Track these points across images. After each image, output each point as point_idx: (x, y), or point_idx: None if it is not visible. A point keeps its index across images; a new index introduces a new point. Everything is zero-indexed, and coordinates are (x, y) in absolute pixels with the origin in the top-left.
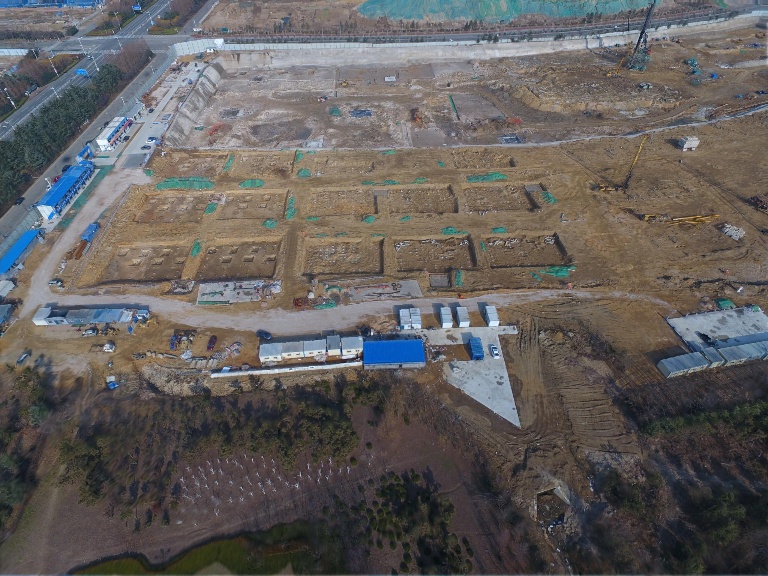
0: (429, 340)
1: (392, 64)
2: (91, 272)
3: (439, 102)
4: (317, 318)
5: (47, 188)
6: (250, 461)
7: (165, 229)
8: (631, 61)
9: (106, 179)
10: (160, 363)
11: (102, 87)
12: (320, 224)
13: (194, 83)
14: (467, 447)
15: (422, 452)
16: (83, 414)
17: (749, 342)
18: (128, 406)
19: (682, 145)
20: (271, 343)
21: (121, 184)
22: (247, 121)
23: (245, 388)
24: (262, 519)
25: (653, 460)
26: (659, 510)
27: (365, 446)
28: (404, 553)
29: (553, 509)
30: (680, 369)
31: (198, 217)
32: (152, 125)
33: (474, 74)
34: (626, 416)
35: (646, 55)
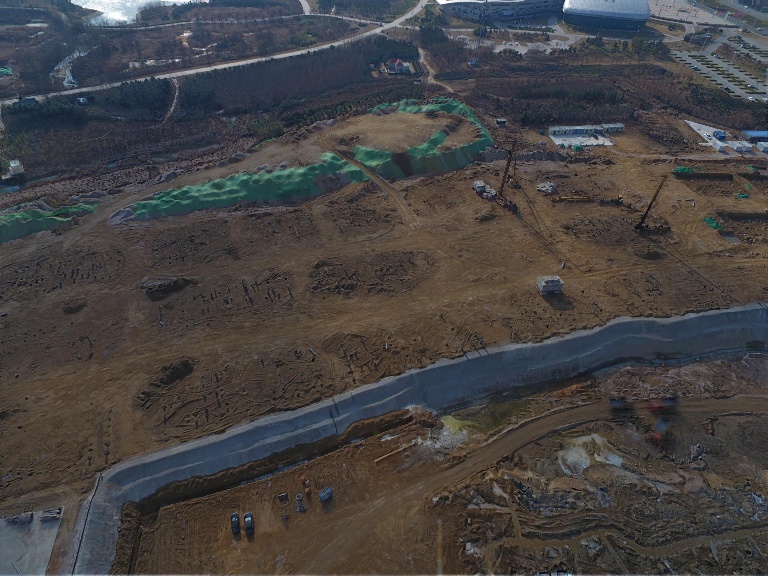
0: None
1: None
2: None
3: None
4: None
5: None
6: None
7: None
8: None
9: None
10: None
11: None
12: None
13: None
14: None
15: None
16: None
17: (572, 135)
18: None
19: None
20: None
21: None
22: None
23: None
24: (766, 110)
25: None
26: None
27: None
28: None
29: None
30: None
31: None
32: None
33: None
34: None
35: None
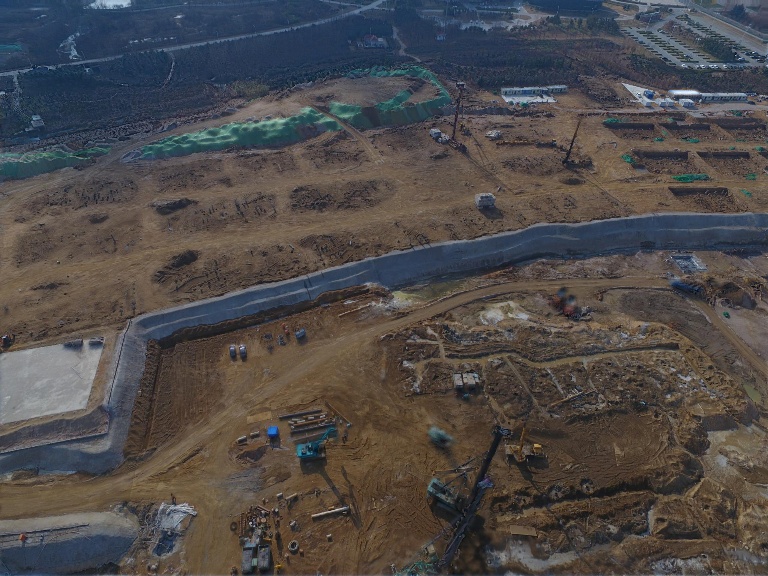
0: (671, 99)
1: None
2: None
3: None
4: (733, 107)
5: None
6: None
7: None
8: None
9: None
10: None
11: None
12: None
13: None
14: None
15: None
16: None
17: (521, 95)
18: None
19: None
20: None
21: None
22: None
23: None
24: None
25: None
26: None
27: (675, 83)
28: None
29: None
30: (560, 85)
31: None
32: None
33: None
34: None
35: None
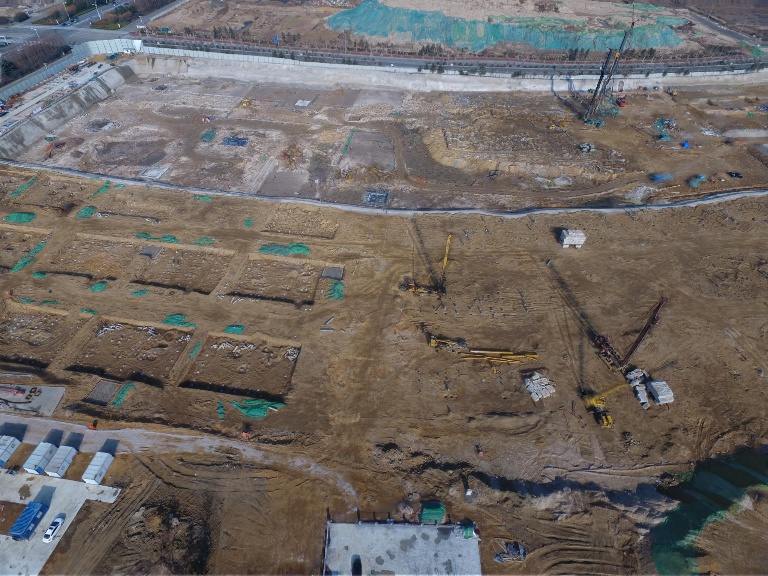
0: None
1: (317, 86)
2: None
3: (333, 138)
4: None
5: None
6: None
7: None
8: (587, 114)
9: None
10: None
11: None
12: (40, 284)
13: (78, 87)
14: None
15: None
16: None
17: None
18: None
19: (562, 240)
20: None
21: None
22: (106, 136)
23: None
24: None
25: None
26: None
27: None
28: None
29: None
30: None
31: None
32: None
33: (398, 108)
34: None
35: (614, 107)
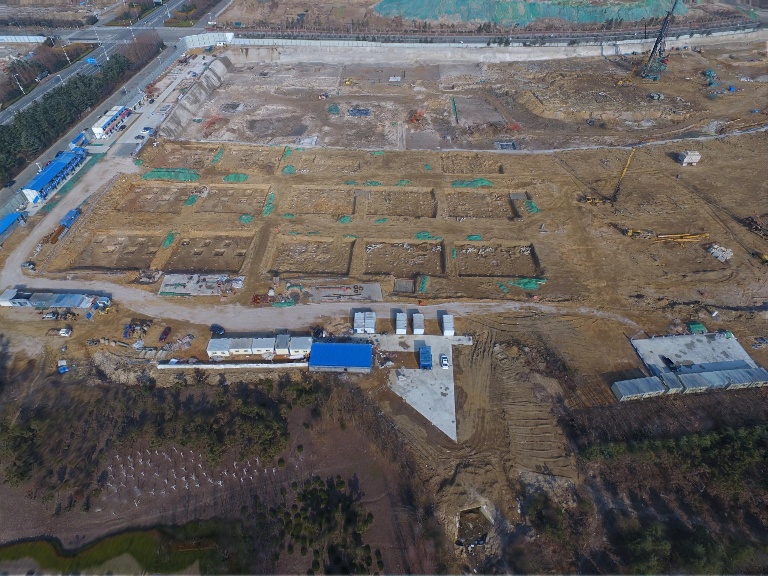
0: (380, 345)
1: (399, 64)
2: (64, 257)
3: (440, 104)
4: (273, 316)
5: (38, 172)
6: (179, 454)
7: (143, 218)
8: (645, 70)
9: (96, 166)
10: (112, 351)
11: (109, 76)
12: (295, 222)
13: (198, 76)
14: (395, 457)
15: (352, 459)
16: (29, 396)
17: (715, 370)
18: (73, 391)
19: (682, 159)
20: (222, 338)
21: (109, 172)
22: (245, 115)
23: (190, 381)
24: (180, 513)
25: (588, 486)
26: (583, 539)
27: (296, 448)
28: (313, 560)
29: (476, 528)
30: (633, 393)
31: (178, 208)
32: (150, 115)
33: (481, 77)
34: (569, 438)
35: (662, 64)
